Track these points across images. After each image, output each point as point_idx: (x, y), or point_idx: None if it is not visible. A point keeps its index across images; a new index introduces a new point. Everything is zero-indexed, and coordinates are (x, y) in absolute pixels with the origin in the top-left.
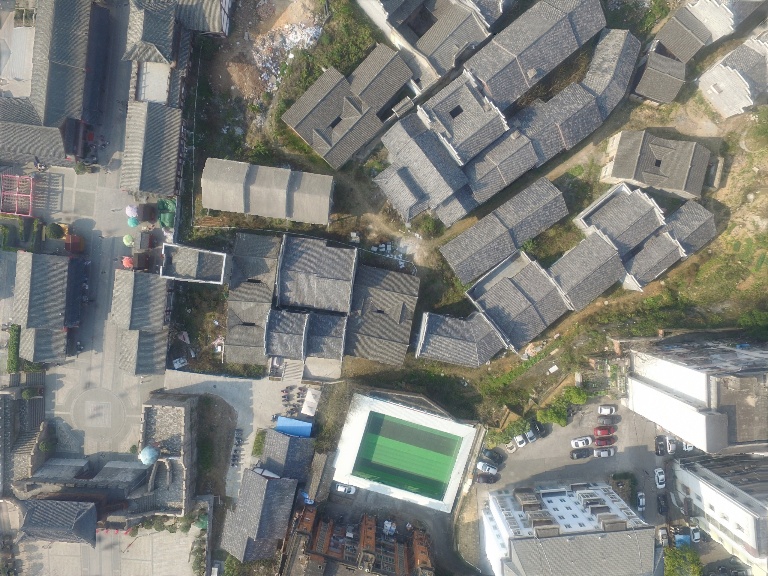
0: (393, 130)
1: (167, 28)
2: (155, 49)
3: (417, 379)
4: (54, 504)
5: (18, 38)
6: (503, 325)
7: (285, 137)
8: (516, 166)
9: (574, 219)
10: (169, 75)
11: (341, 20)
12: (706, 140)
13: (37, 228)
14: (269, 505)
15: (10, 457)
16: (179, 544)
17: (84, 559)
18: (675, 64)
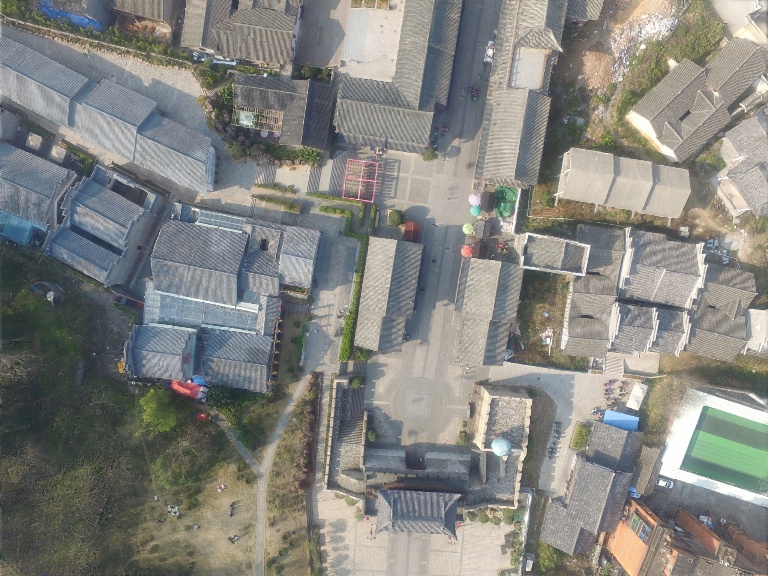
0: (745, 125)
1: (561, 14)
2: (550, 35)
3: (731, 375)
4: (416, 494)
5: (356, 19)
6: None
7: (625, 129)
8: None
9: None
10: (545, 62)
11: (697, 12)
12: None
13: (374, 214)
14: (610, 498)
15: (337, 446)
16: (490, 536)
17: (391, 550)
18: None
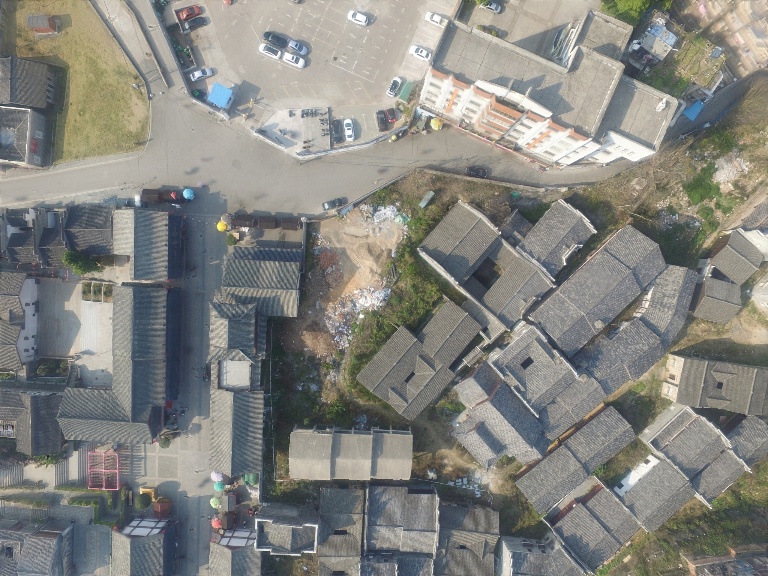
0: (466, 383)
1: (249, 329)
2: (239, 351)
3: None
4: None
5: (88, 311)
6: (583, 556)
7: (359, 389)
8: (586, 406)
9: (640, 437)
10: (250, 363)
11: (408, 281)
12: (760, 347)
13: (124, 496)
14: None
15: None
16: None
17: None
18: (731, 288)
